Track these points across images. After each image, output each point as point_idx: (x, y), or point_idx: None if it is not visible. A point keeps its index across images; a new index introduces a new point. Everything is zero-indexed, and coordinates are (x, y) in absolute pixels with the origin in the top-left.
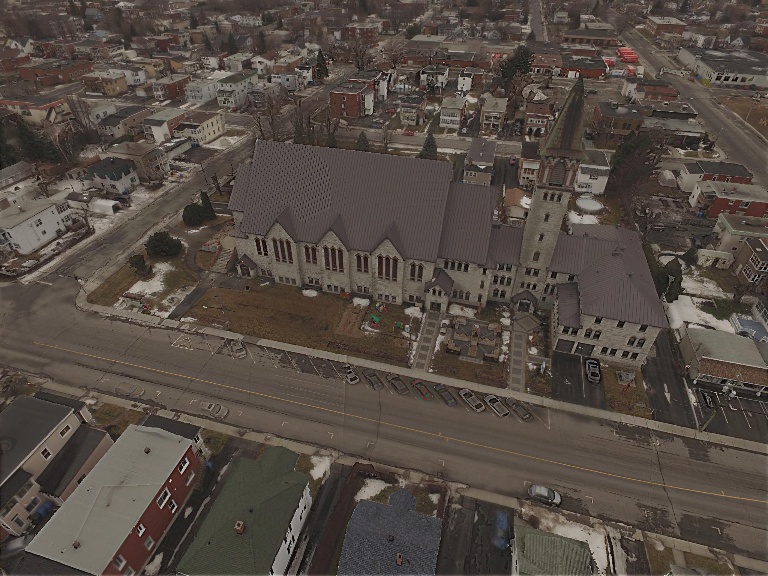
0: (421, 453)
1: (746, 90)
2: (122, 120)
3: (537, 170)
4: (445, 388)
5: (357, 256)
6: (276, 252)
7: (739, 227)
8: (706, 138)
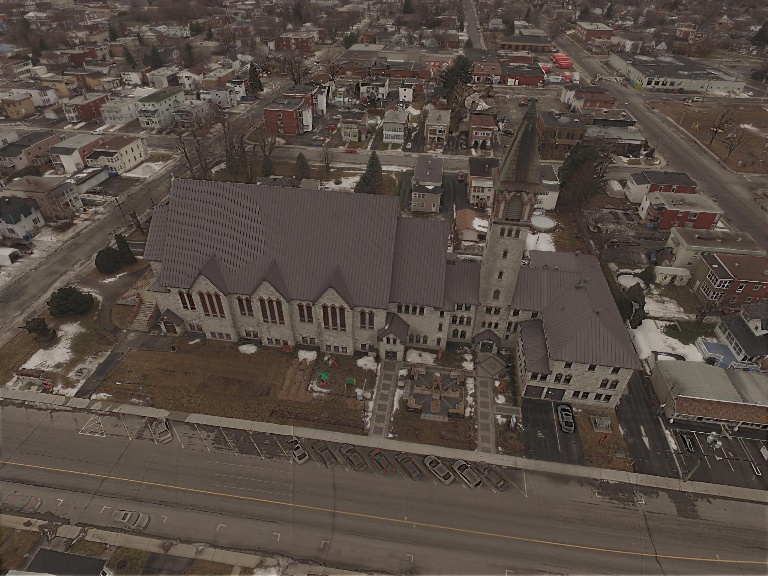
0: (385, 548)
1: (675, 94)
2: (24, 149)
3: (487, 188)
4: (408, 457)
5: (299, 306)
6: (204, 306)
7: (693, 242)
8: (646, 145)
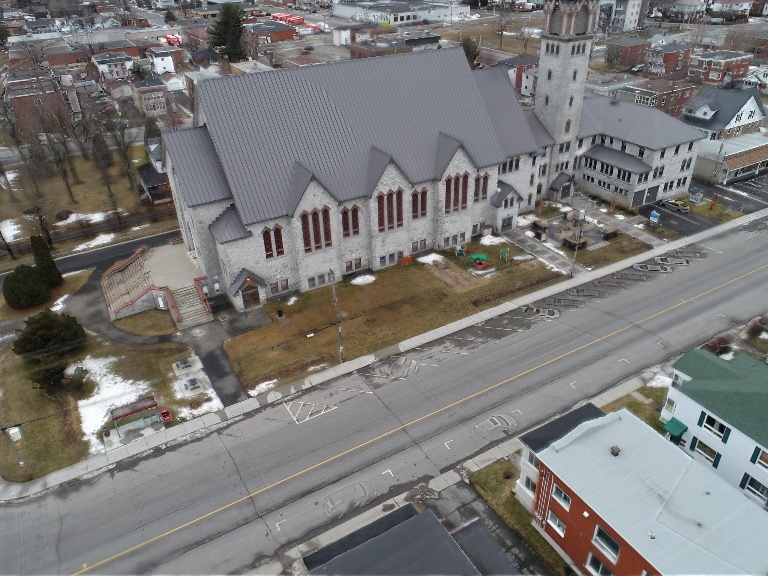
0: (699, 320)
1: (423, 25)
2: None
3: None
4: (622, 273)
5: (413, 195)
6: (304, 237)
7: (603, 85)
8: None
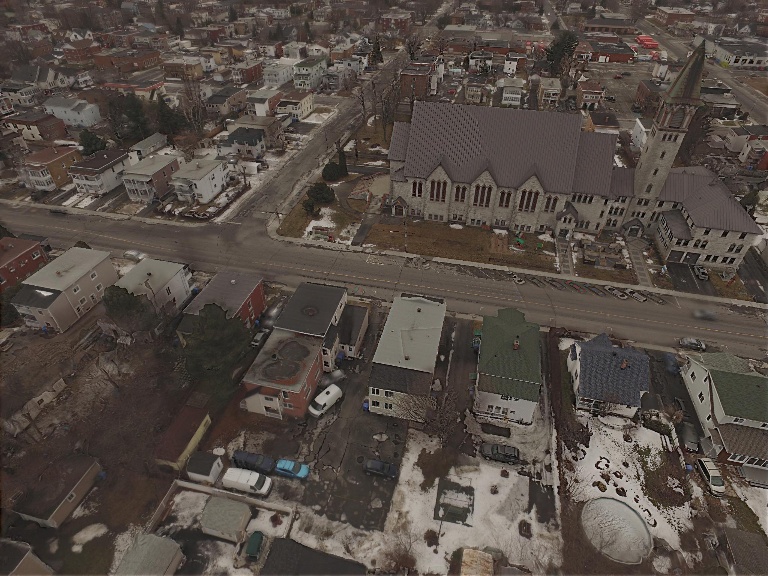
0: (592, 323)
1: (762, 71)
2: (227, 99)
3: None
4: (592, 286)
5: (501, 193)
6: (431, 192)
7: None
8: (739, 110)
